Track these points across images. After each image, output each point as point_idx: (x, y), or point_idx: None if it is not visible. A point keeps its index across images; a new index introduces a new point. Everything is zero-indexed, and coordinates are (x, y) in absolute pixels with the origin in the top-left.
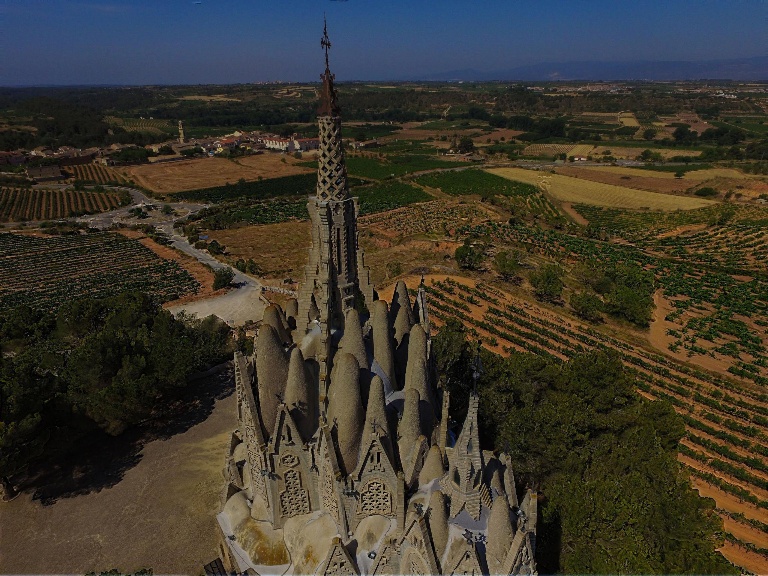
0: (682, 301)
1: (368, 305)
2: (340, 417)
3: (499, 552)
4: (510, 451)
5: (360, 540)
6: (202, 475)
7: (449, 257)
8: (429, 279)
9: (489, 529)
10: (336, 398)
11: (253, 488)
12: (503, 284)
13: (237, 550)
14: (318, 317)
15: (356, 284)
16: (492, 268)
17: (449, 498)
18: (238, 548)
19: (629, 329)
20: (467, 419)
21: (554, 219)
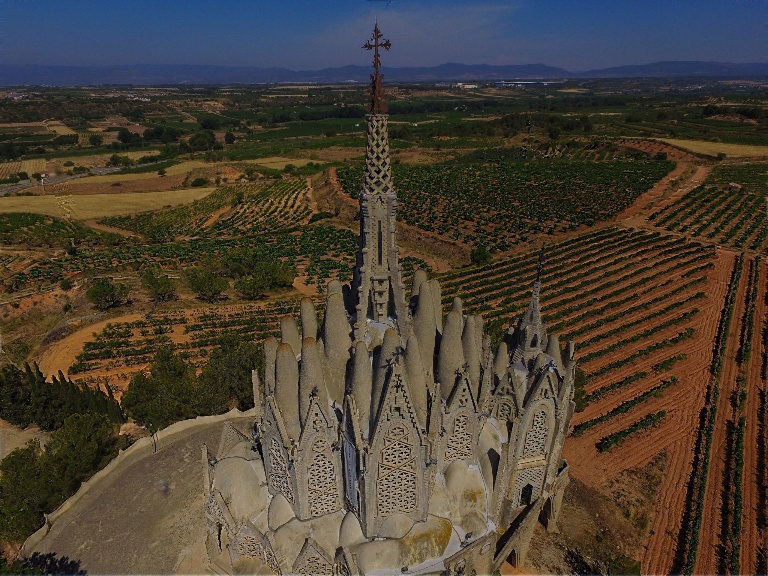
0: (287, 261)
1: None
2: (461, 365)
3: (562, 365)
4: None
5: (494, 445)
6: None
7: (70, 307)
8: (81, 337)
9: (555, 357)
10: (451, 355)
11: (372, 525)
12: (165, 304)
13: (420, 569)
14: (352, 322)
15: (41, 374)
16: (146, 293)
17: (533, 360)
18: (418, 567)
19: (286, 292)
20: (535, 300)
21: (109, 237)
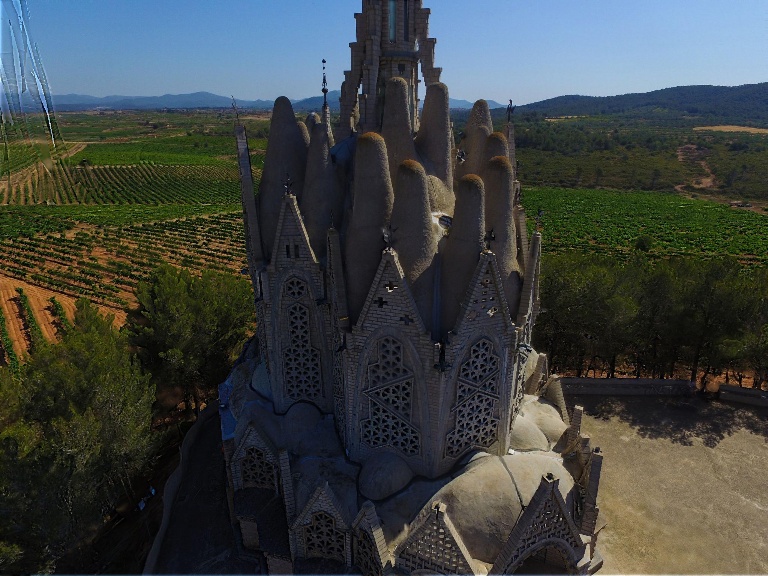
0: None
1: (355, 103)
2: None
3: None
4: (153, 397)
5: None
6: (663, 574)
7: None
8: None
9: None
10: None
11: None
12: None
13: None
14: None
15: None
16: None
17: None
18: None
19: None
20: None
21: None
